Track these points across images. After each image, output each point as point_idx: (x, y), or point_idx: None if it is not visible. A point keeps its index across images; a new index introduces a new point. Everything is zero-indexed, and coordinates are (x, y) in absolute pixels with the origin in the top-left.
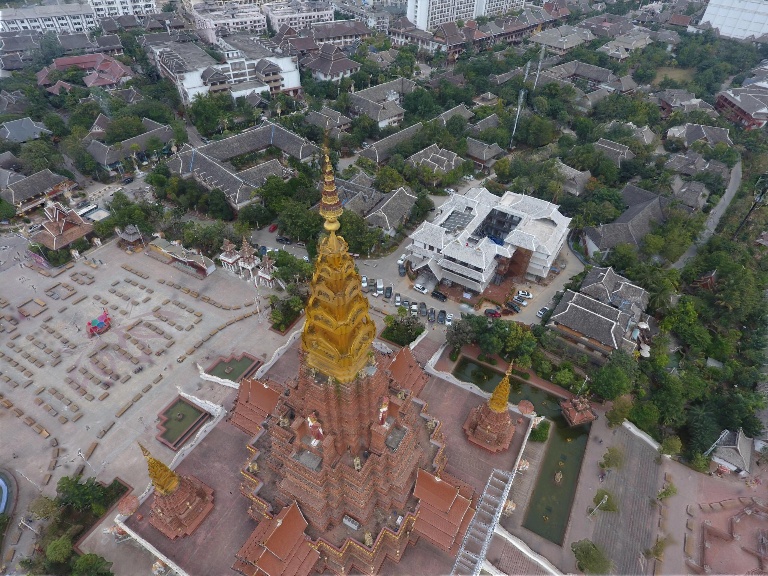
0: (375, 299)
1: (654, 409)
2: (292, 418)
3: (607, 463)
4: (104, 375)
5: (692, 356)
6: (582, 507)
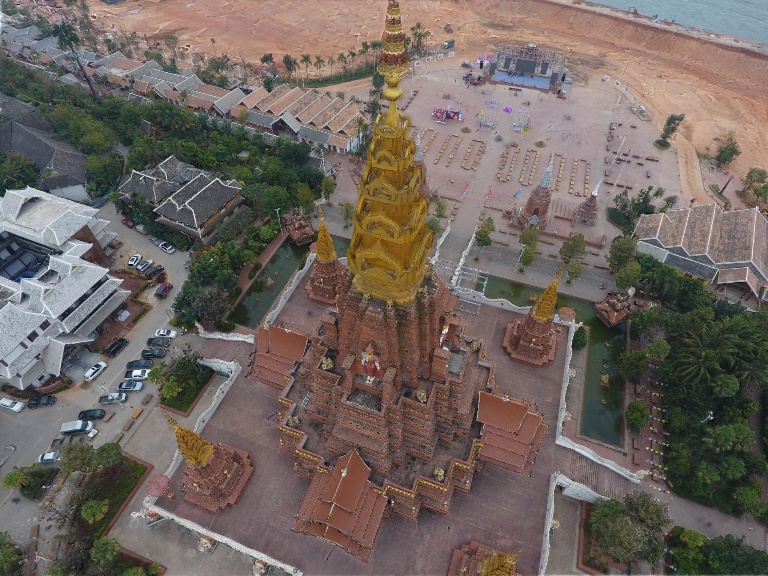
0: (102, 434)
1: (301, 184)
2: (411, 394)
3: None
4: None
5: (237, 162)
6: None
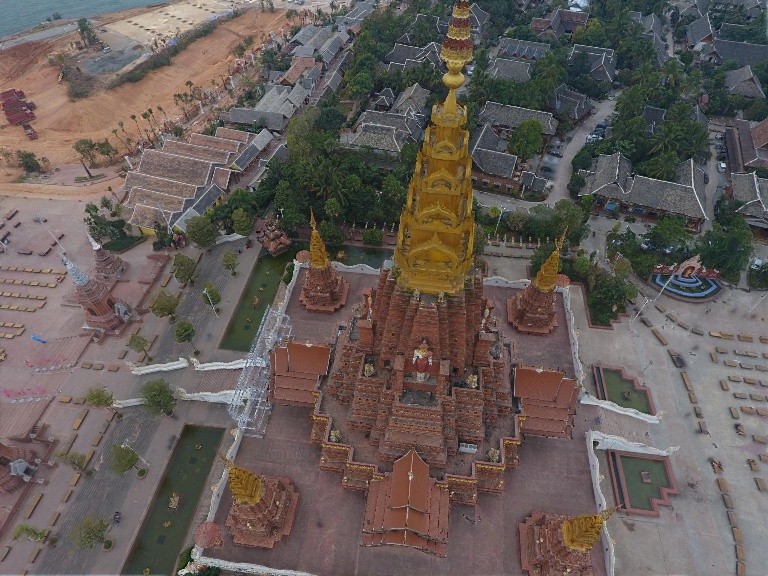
0: None
1: None
2: None
3: (102, 524)
4: (762, 408)
5: None
6: (153, 474)
